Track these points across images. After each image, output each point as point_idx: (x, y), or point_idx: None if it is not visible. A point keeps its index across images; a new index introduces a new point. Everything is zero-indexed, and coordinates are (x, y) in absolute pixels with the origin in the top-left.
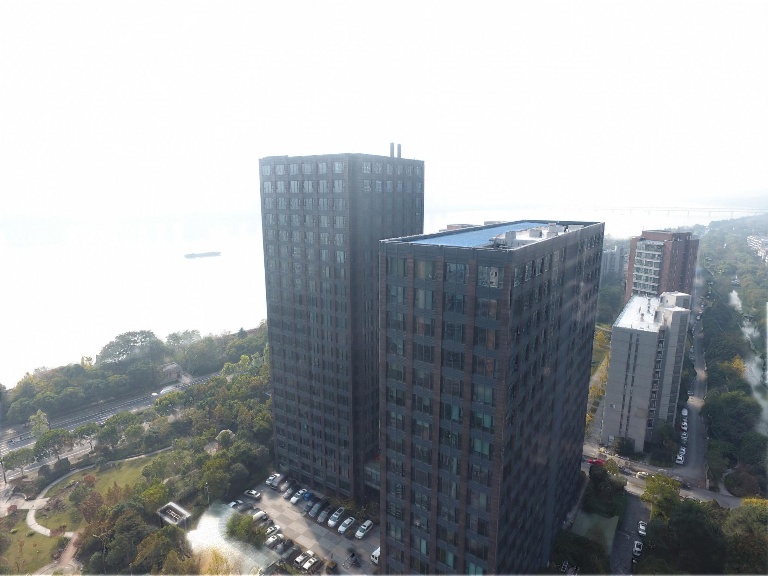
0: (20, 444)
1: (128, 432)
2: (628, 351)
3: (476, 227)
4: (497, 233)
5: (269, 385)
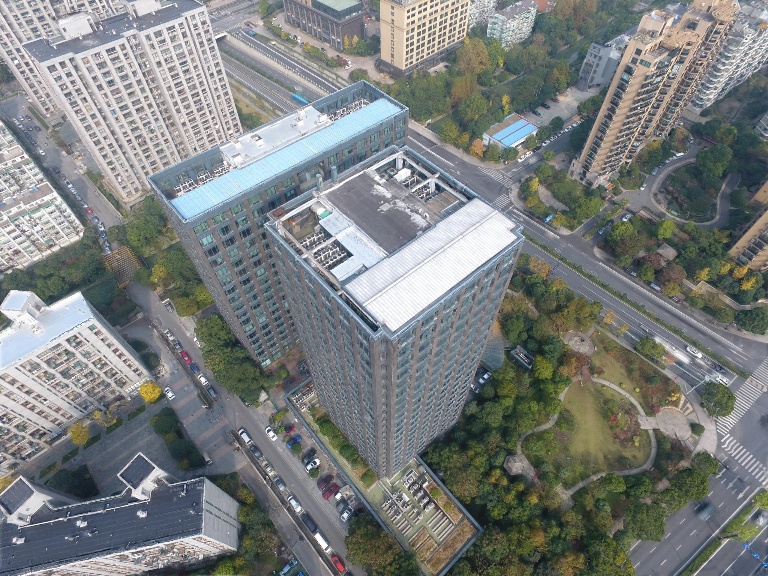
0: (760, 550)
1: (619, 476)
2: (102, 321)
3: (306, 159)
4: (301, 149)
5: (479, 540)
